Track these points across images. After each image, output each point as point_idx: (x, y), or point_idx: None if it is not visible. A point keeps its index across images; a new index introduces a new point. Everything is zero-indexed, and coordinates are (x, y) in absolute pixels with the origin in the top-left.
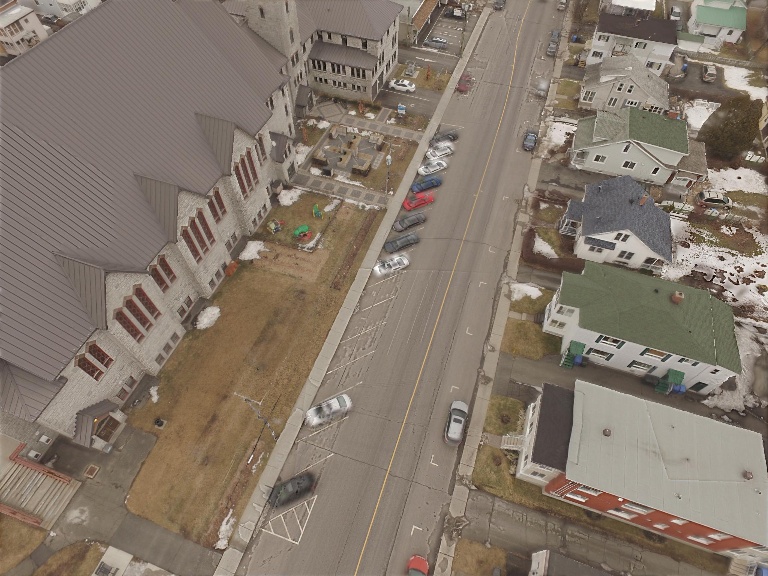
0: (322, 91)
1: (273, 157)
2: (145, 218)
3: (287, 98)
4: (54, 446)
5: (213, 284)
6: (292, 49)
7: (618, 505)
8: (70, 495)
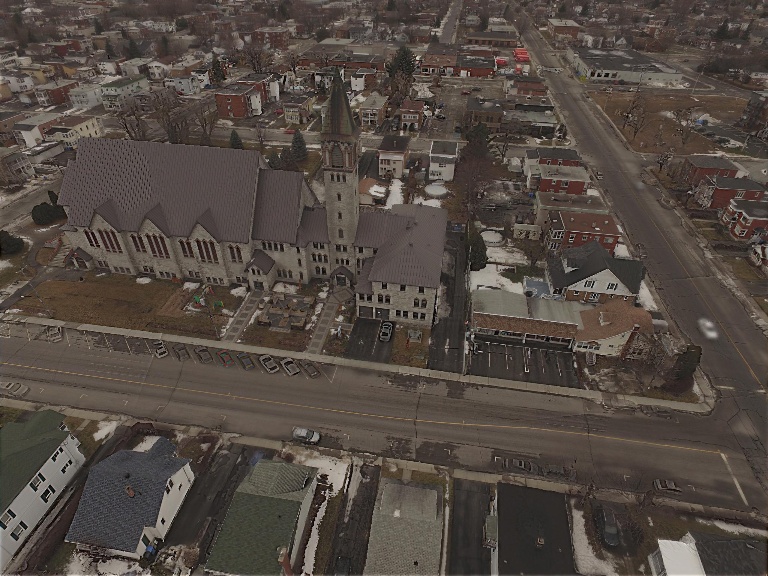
0: None
1: None
2: None
3: (303, 257)
4: None
5: None
6: (340, 241)
7: None
8: (60, 265)
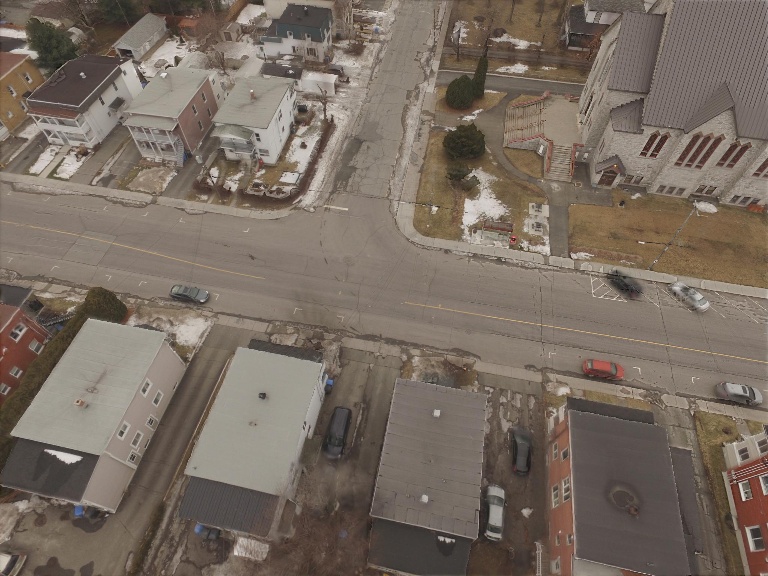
0: None
1: None
2: None
3: None
4: (582, 163)
5: (734, 201)
6: None
7: (767, 520)
8: (563, 179)
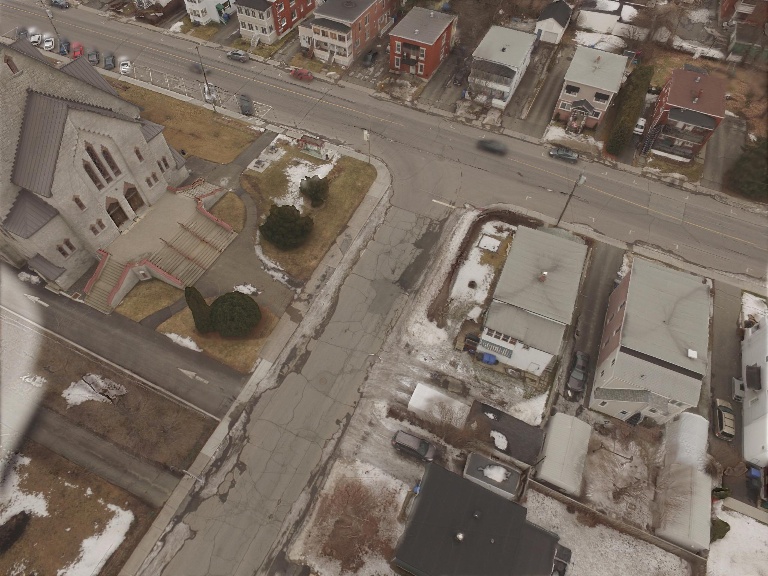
0: None
1: None
2: None
3: None
4: None
5: None
6: None
7: None
8: None
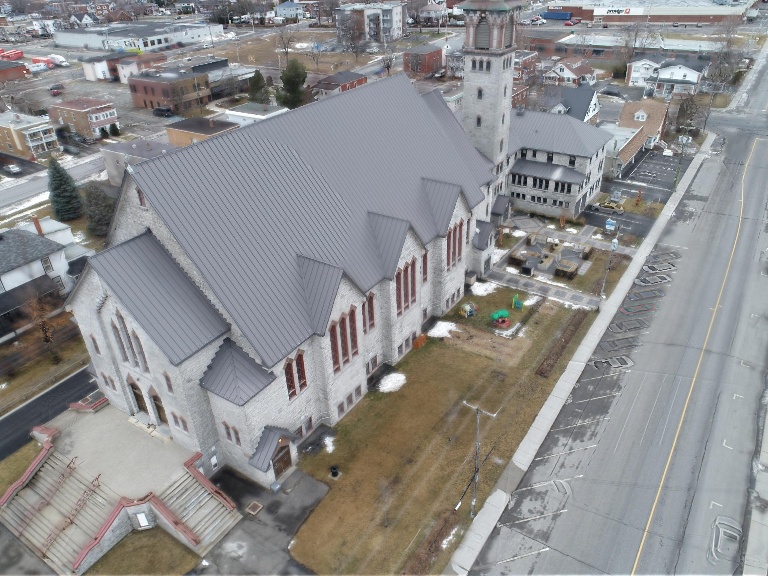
0: (517, 207)
1: (475, 244)
2: (370, 251)
3: (490, 198)
4: (218, 475)
5: (400, 352)
6: (499, 158)
7: None
8: (230, 526)
